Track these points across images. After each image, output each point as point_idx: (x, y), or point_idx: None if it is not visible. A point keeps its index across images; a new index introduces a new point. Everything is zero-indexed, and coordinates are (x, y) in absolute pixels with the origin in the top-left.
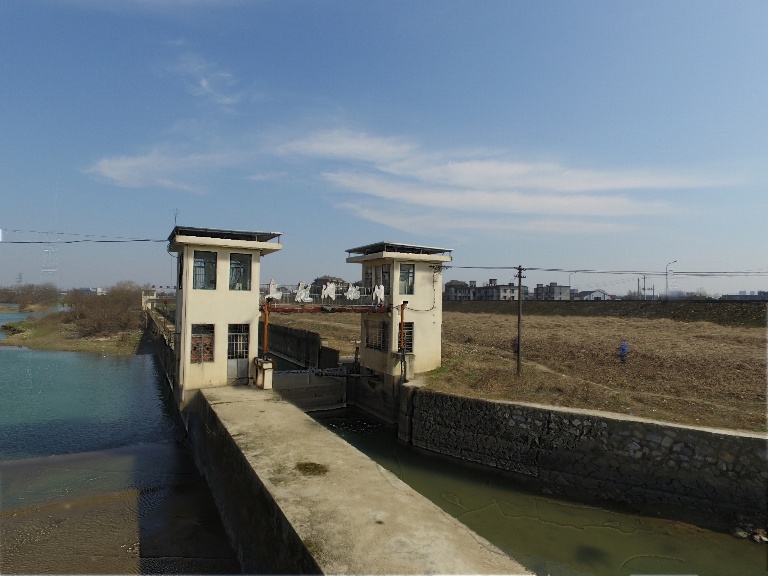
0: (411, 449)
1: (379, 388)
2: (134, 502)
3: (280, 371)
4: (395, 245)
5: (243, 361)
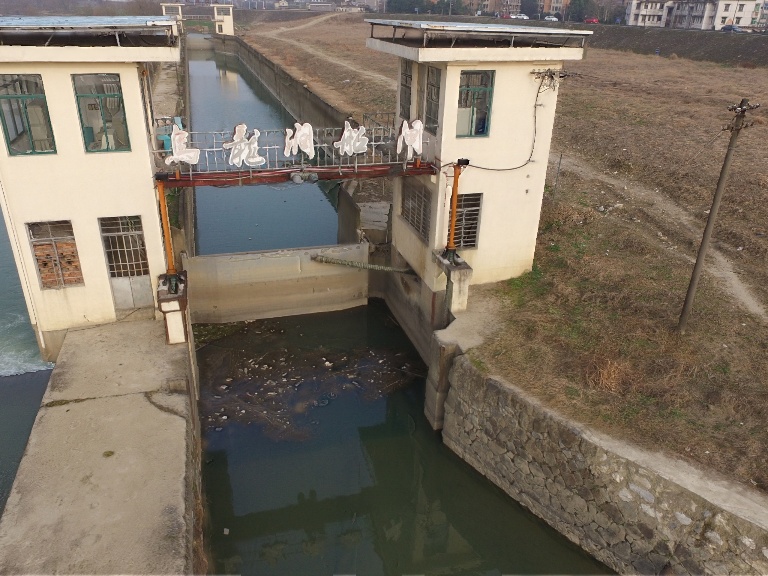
0: (439, 448)
1: (414, 298)
2: None
3: (248, 254)
4: (449, 31)
5: (141, 280)
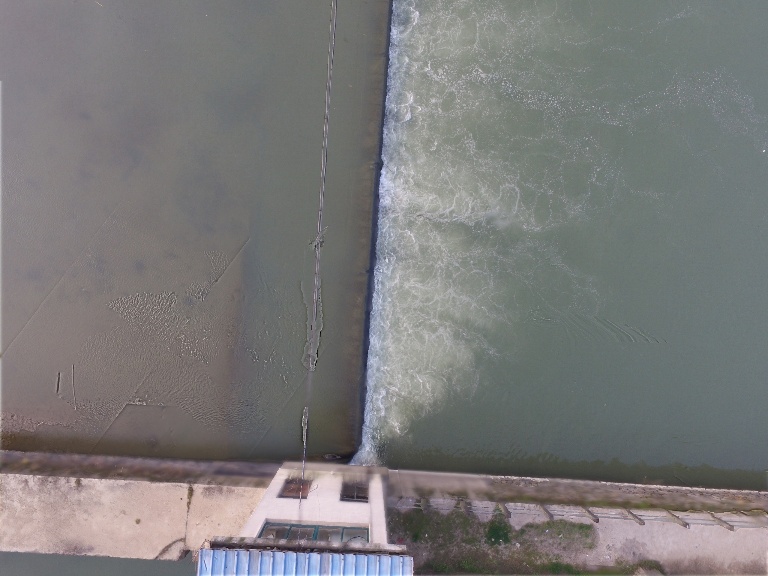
0: None
1: None
2: (210, 405)
3: None
4: None
5: None
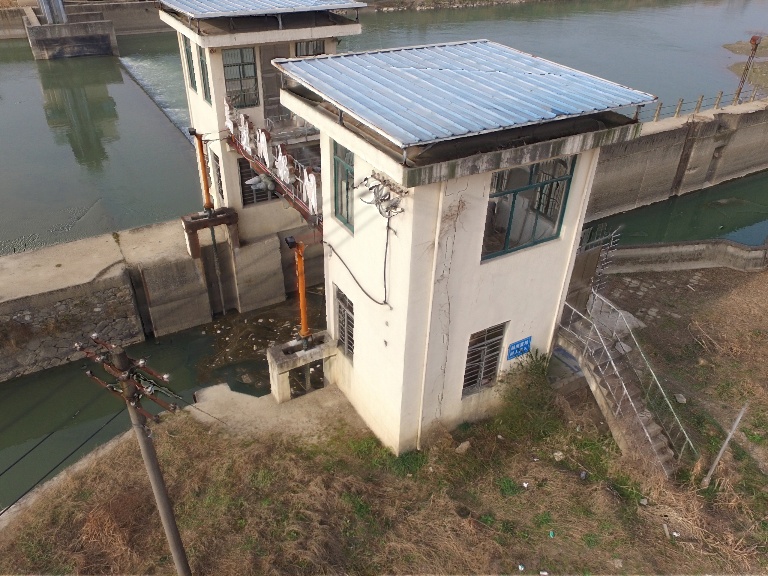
0: None
1: None
2: None
3: None
4: None
5: None
